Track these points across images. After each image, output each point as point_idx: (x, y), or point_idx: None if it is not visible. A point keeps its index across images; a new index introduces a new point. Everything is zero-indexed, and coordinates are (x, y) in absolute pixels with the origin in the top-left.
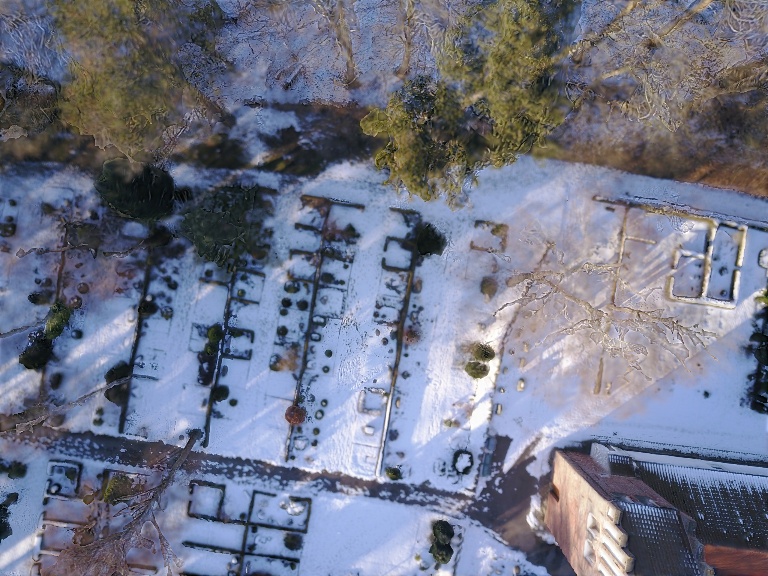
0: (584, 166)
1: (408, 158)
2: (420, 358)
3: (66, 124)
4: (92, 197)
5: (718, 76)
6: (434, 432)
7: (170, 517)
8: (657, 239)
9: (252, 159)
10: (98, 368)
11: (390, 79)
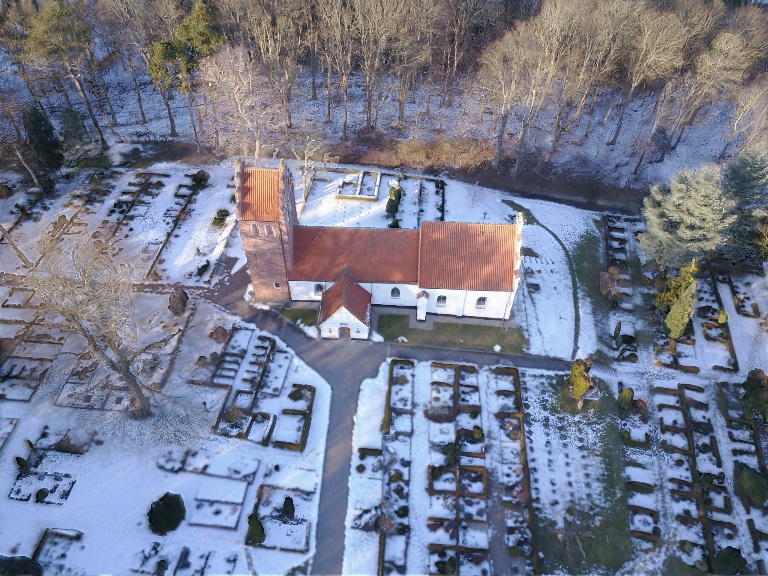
0: (294, 160)
1: (158, 54)
2: (188, 229)
3: None
4: (17, 180)
5: (360, 129)
6: (189, 259)
7: None
8: (331, 179)
9: (114, 163)
10: None
11: None
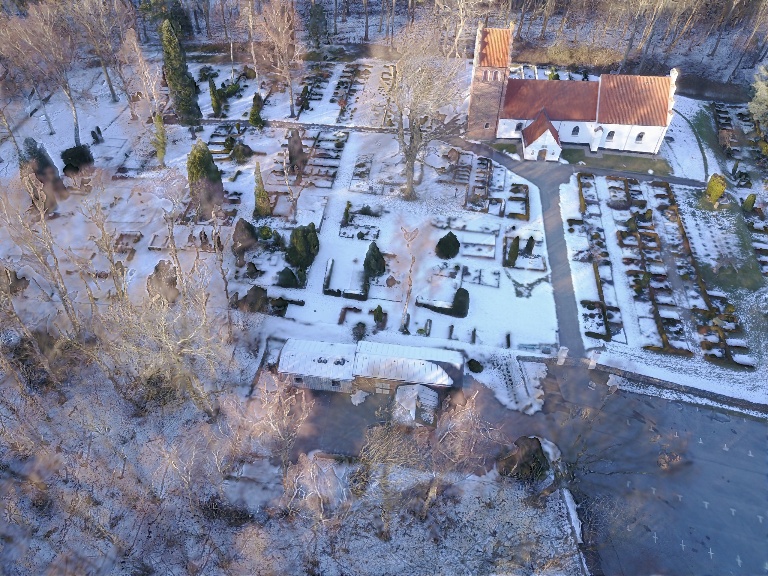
0: None
1: None
2: None
3: (249, 51)
4: None
5: None
6: None
7: (275, 140)
8: None
9: None
10: (247, 104)
11: (382, 40)
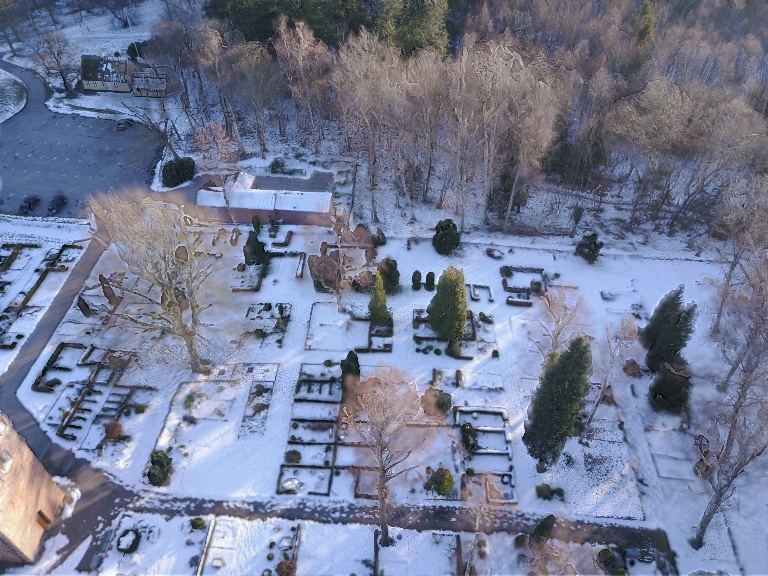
0: None
1: None
2: None
3: None
4: None
5: None
6: (154, 569)
7: (402, 466)
8: None
9: None
10: None
11: None
